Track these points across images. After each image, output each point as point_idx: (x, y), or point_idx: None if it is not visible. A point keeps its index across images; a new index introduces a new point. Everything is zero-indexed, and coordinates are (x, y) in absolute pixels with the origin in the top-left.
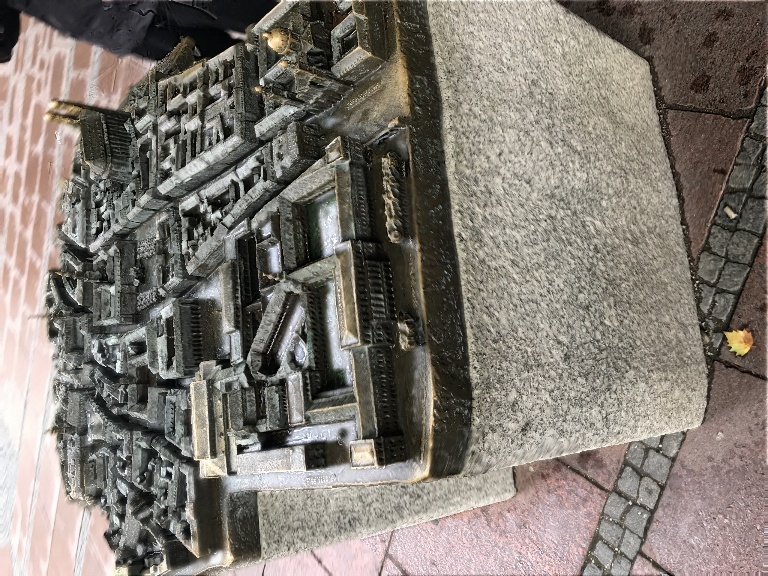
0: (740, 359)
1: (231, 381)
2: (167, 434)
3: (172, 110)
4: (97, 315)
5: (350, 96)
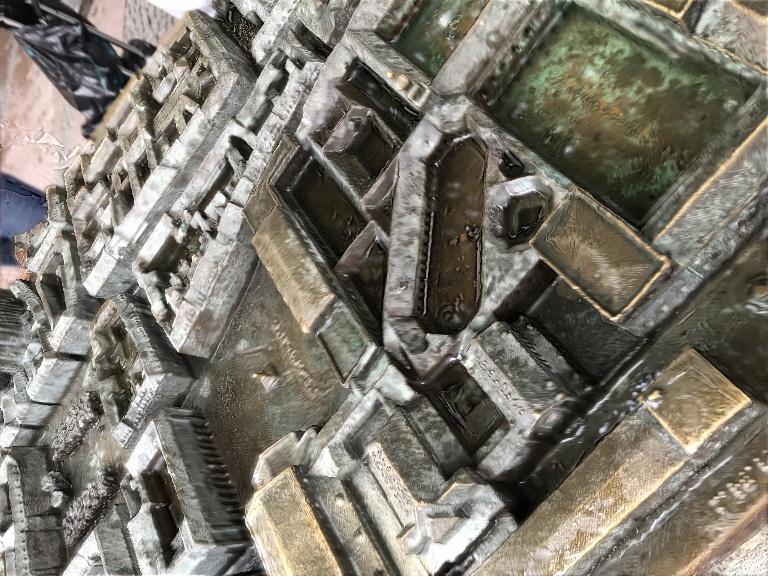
0: None
1: (356, 429)
2: None
3: (93, 180)
4: None
5: None
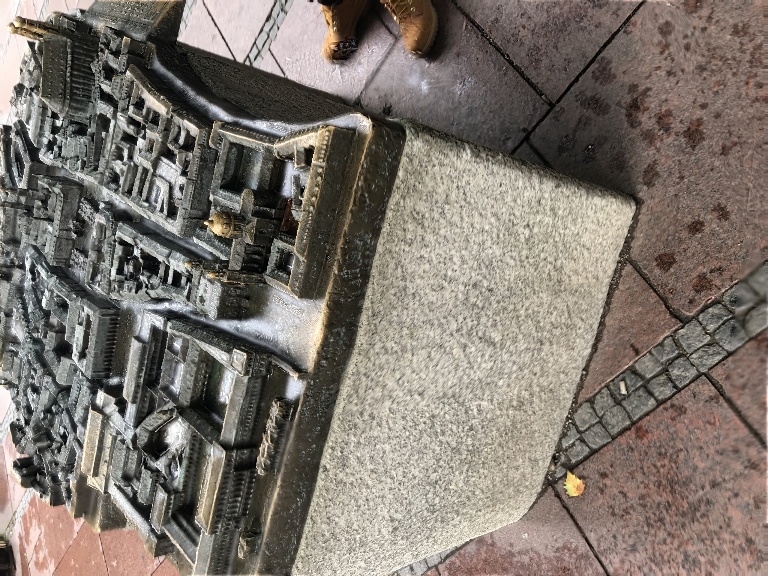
0: (567, 497)
1: None
2: (70, 405)
3: None
4: (34, 234)
5: (278, 290)
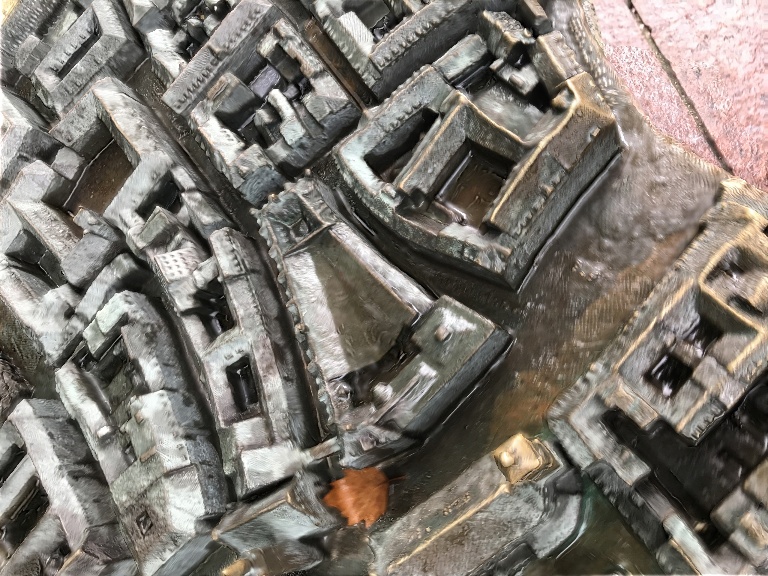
0: None
1: None
2: None
3: None
4: None
5: None
